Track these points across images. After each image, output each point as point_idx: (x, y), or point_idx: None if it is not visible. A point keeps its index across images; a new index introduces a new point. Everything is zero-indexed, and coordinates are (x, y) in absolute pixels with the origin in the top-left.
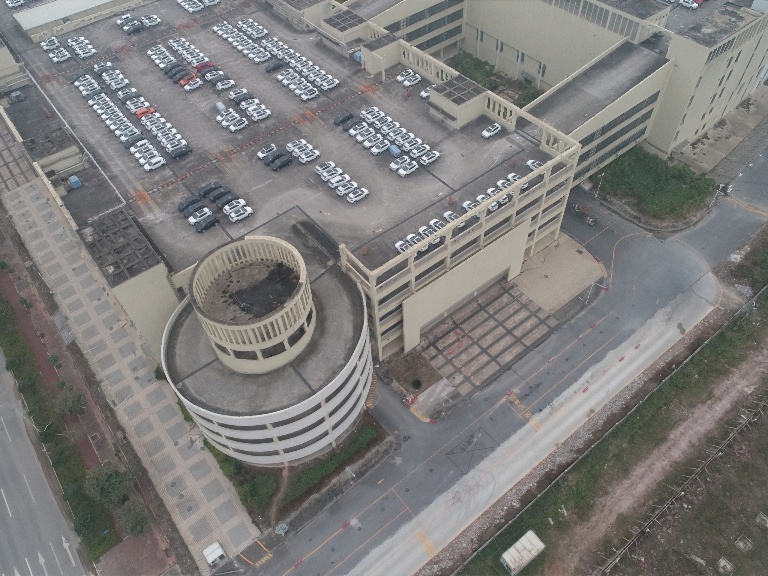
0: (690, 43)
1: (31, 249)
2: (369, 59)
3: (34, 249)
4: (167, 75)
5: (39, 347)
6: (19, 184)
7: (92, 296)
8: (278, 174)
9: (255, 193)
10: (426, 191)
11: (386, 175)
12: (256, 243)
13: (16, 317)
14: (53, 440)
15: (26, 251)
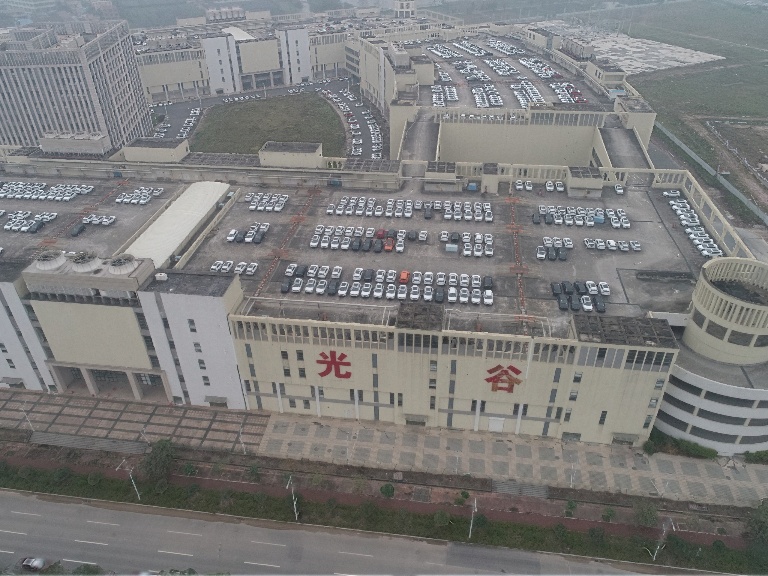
0: (642, 115)
1: (379, 465)
2: (493, 182)
3: (382, 463)
4: (359, 251)
5: (528, 518)
6: (259, 433)
7: (500, 452)
8: (570, 261)
9: (581, 277)
10: (652, 229)
11: (619, 232)
12: (707, 269)
13: (468, 517)
14: (666, 556)
15: (377, 469)
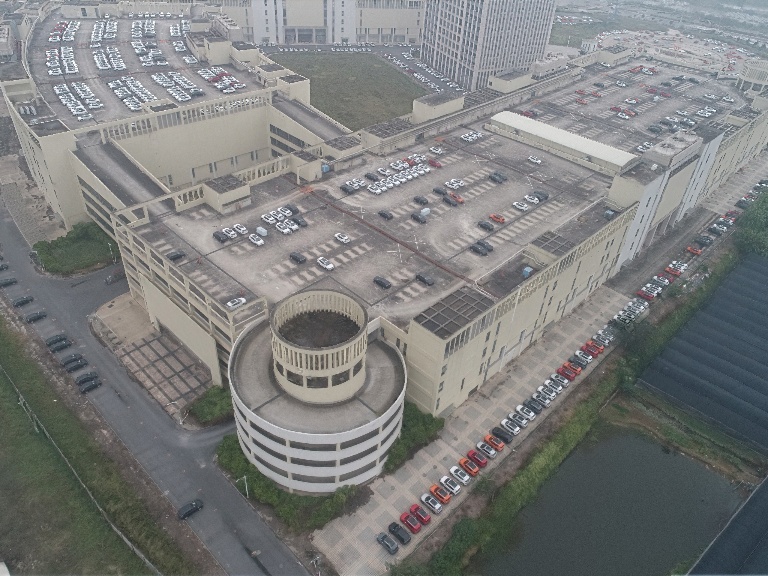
0: None
1: None
2: None
3: None
4: None
5: None
6: None
7: None
8: None
9: None
10: None
11: None
12: None
13: None
14: None
15: None
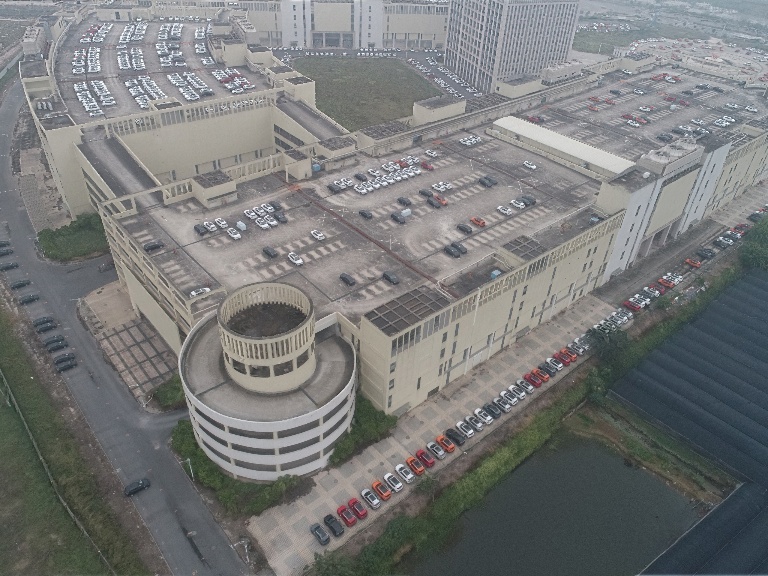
0: None
1: None
2: None
3: None
4: None
5: None
6: None
7: None
8: None
9: None
10: None
11: None
12: None
13: None
14: None
15: None
